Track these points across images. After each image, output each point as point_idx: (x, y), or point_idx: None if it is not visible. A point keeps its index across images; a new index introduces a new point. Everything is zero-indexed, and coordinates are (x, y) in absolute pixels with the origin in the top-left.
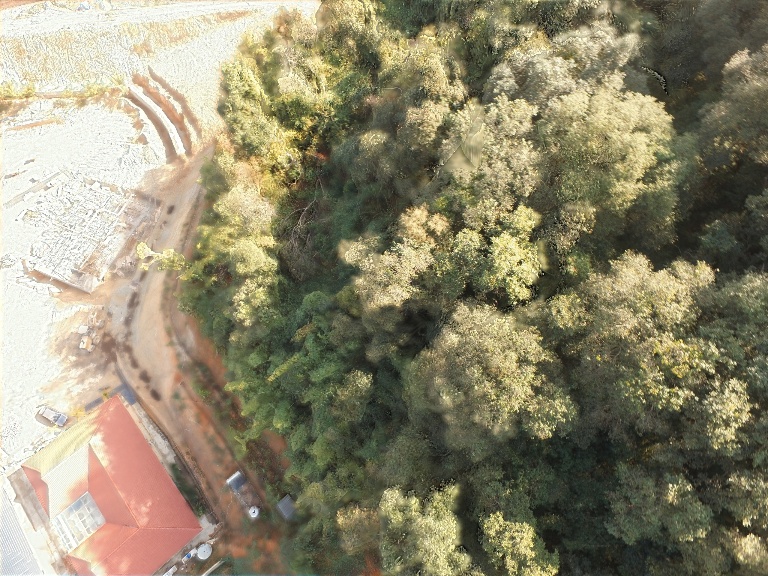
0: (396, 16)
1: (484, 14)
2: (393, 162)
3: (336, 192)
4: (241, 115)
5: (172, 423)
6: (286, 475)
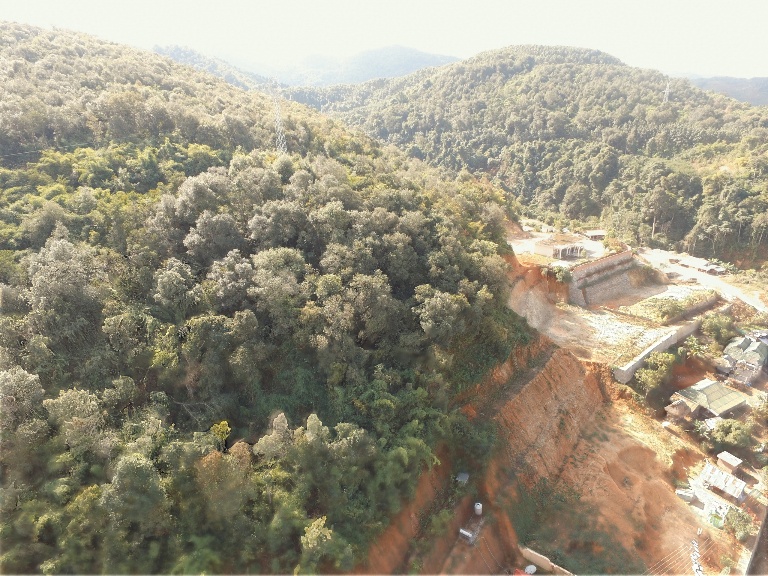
0: None
1: (169, 303)
2: (258, 340)
3: None
4: (188, 444)
5: None
6: (441, 429)
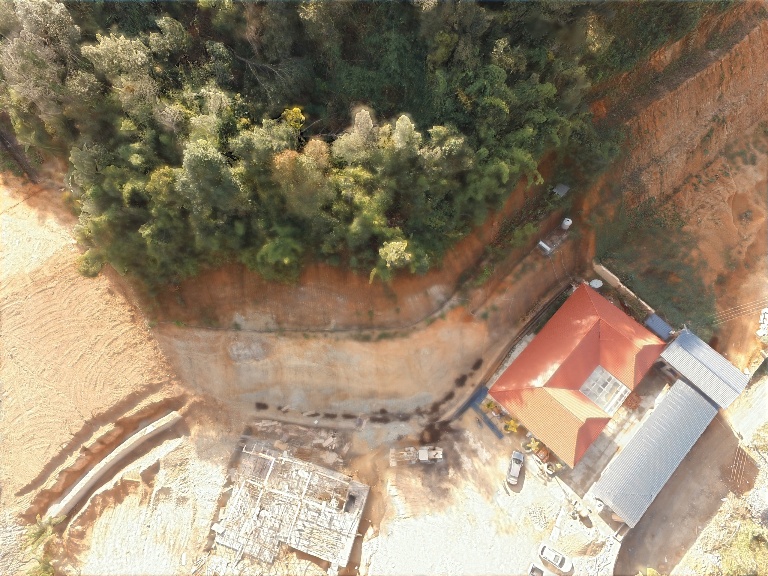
0: (125, 35)
1: None
2: None
3: (318, 106)
4: (256, 139)
5: (501, 341)
6: (558, 140)
